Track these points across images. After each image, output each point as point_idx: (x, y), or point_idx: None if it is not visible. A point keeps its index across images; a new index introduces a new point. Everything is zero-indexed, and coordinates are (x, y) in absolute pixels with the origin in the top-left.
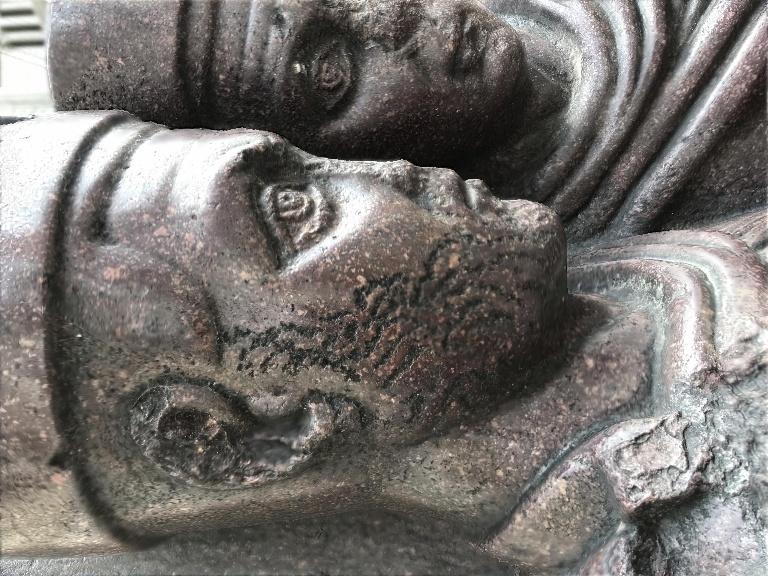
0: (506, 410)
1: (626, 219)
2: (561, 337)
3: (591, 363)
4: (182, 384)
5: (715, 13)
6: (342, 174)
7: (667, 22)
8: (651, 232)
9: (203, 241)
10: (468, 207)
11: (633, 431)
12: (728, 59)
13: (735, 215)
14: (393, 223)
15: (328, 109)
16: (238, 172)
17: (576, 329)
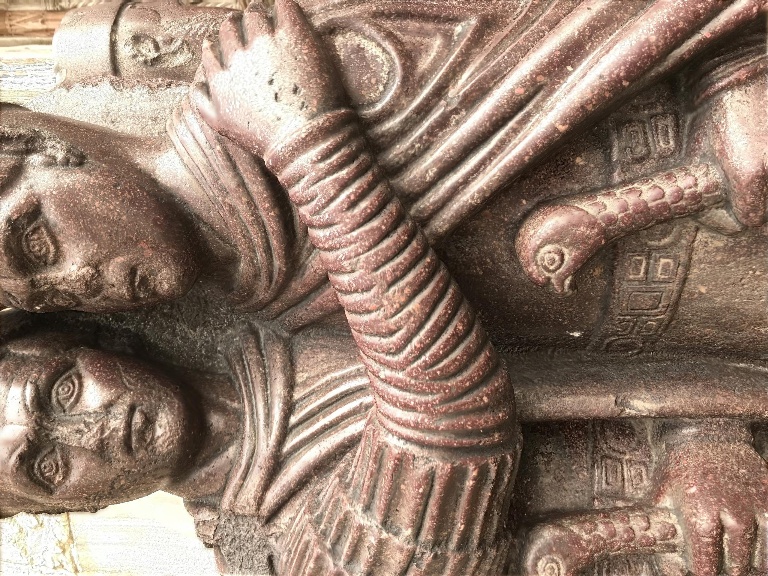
0: (171, 485)
1: (283, 324)
2: (194, 462)
3: (204, 476)
4: (36, 508)
5: (318, 259)
6: (68, 445)
7: (286, 258)
8: (298, 331)
9: (18, 490)
10: (131, 449)
11: (204, 518)
12: (327, 284)
13: (344, 335)
14: (92, 476)
15: (69, 307)
16: (20, 468)
17: (203, 456)
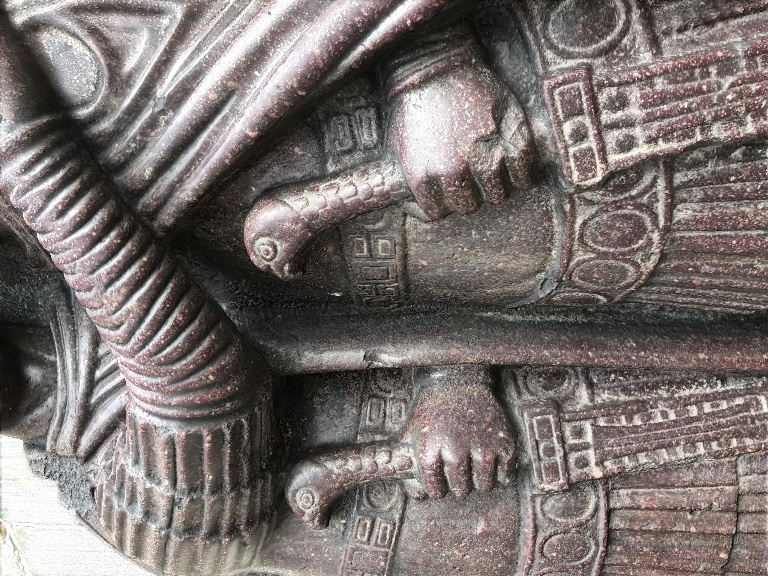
0: None
1: None
2: (18, 411)
3: None
4: None
5: None
6: None
7: None
8: None
9: None
10: None
11: None
12: None
13: None
14: None
15: None
16: None
17: (25, 406)
